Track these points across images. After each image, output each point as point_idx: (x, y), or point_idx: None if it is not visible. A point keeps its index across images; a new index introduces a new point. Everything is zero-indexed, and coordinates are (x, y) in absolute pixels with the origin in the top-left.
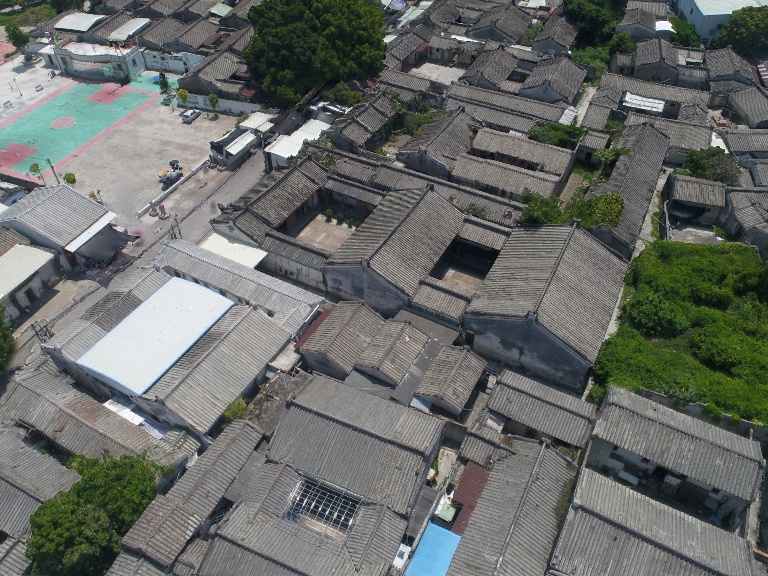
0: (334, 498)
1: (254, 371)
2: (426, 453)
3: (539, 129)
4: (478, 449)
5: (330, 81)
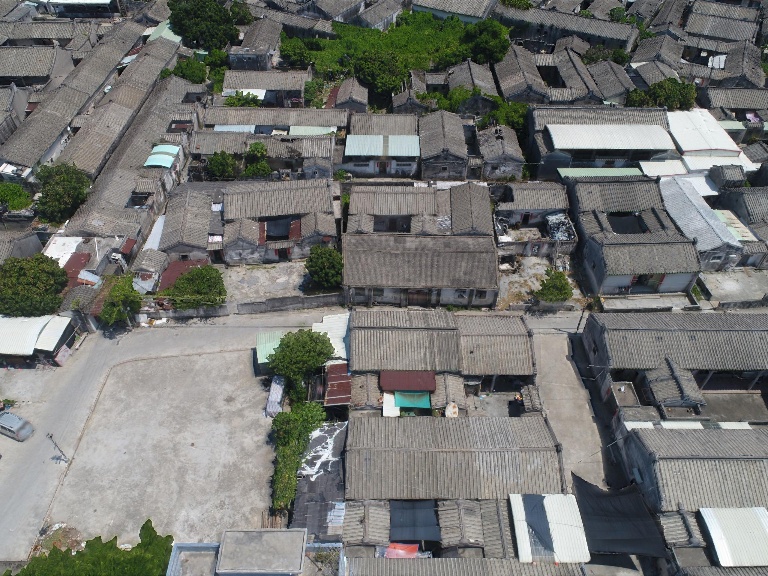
0: None
1: None
2: None
3: (619, 8)
4: None
5: None
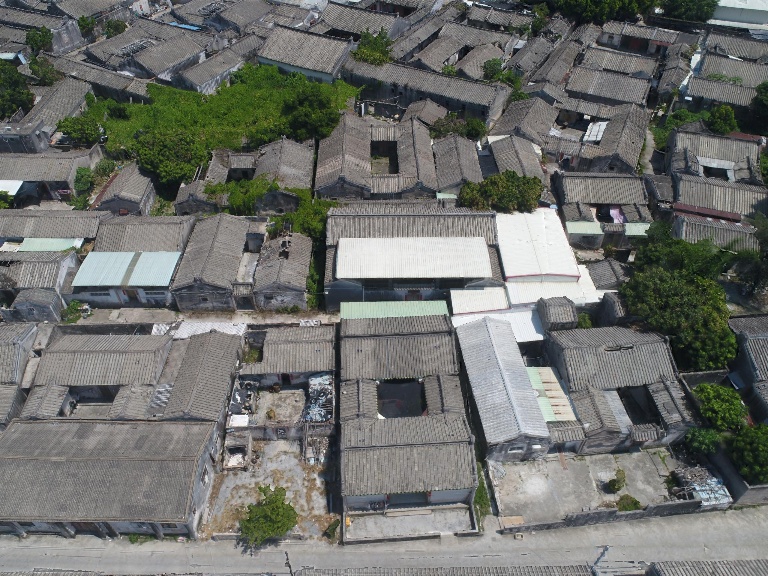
0: (213, 8)
1: (280, 0)
2: None
3: (494, 60)
4: None
5: (548, 3)
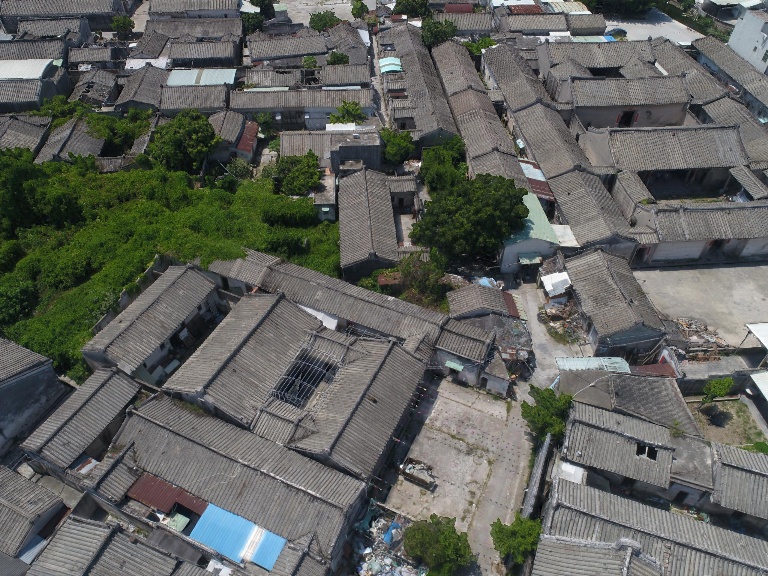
0: None
1: None
2: (116, 525)
3: None
4: (117, 481)
5: None
